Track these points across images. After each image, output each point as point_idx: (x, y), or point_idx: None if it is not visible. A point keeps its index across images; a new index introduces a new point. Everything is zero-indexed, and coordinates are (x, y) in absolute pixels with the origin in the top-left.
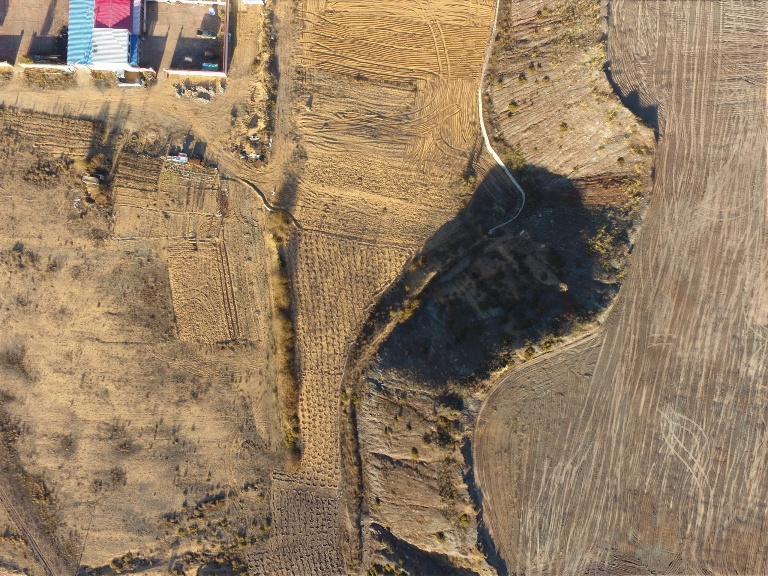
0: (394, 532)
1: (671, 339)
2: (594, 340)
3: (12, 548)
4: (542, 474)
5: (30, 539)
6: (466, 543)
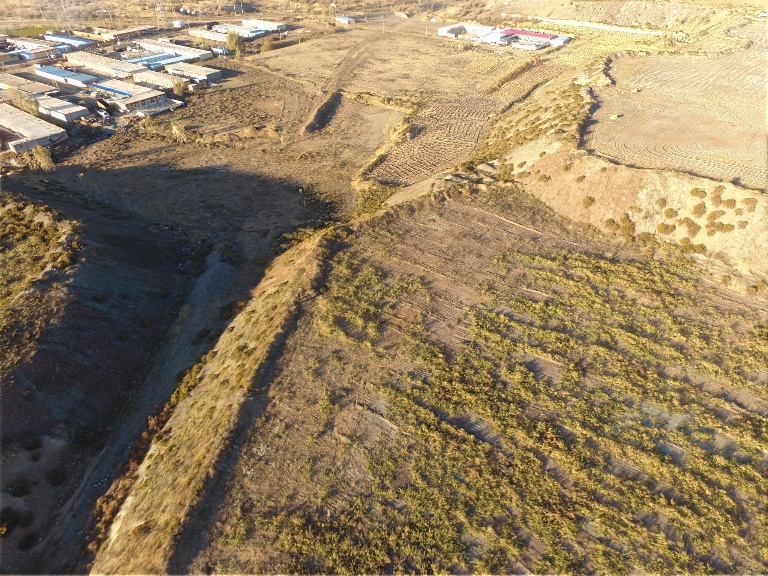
0: None
1: None
2: None
3: None
4: None
5: None
6: None
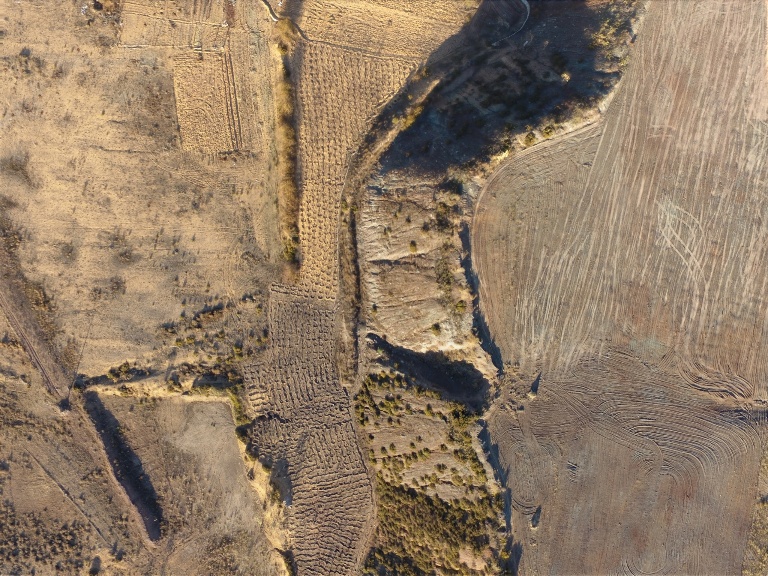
0: (390, 339)
1: (671, 131)
2: (594, 129)
3: (10, 355)
4: (539, 263)
5: (28, 345)
6: (461, 331)
